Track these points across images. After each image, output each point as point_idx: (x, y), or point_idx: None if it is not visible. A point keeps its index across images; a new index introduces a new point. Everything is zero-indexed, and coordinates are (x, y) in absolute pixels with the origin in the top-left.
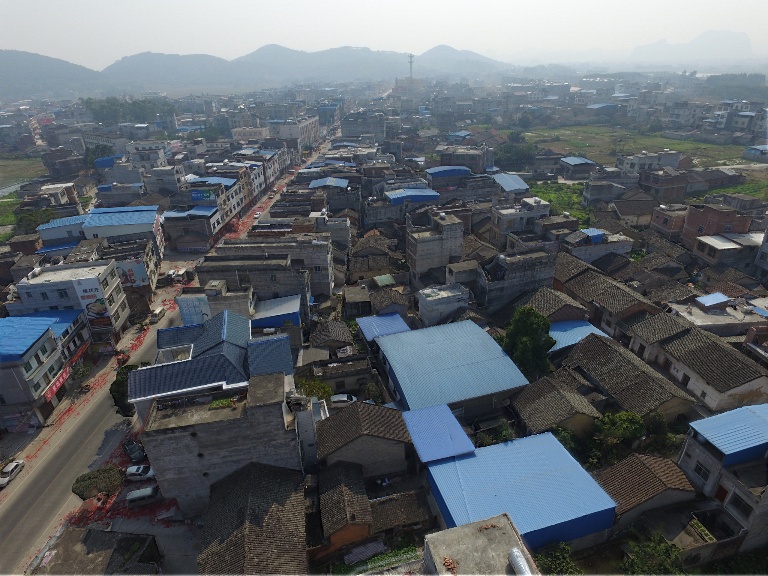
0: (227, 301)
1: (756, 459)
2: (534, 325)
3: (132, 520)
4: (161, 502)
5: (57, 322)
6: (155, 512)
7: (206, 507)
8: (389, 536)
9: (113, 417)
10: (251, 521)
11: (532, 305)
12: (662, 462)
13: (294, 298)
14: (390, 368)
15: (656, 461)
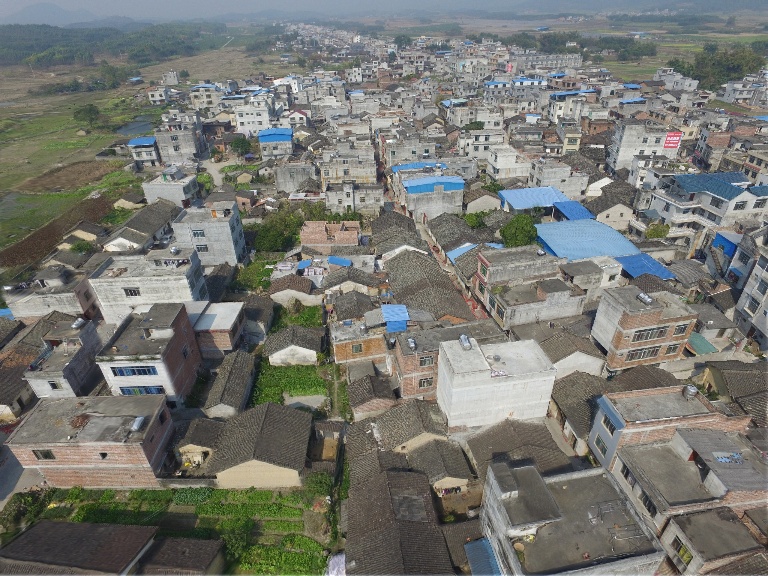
0: None
1: None
2: None
3: None
4: None
5: None
6: None
7: None
8: None
9: None
10: None
11: None
12: None
13: None
14: None
15: (475, 197)
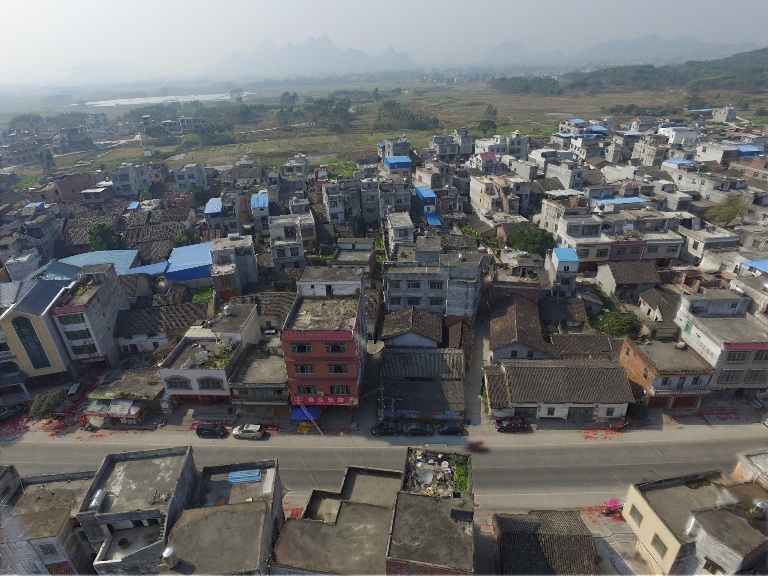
0: None
1: (224, 213)
2: (111, 228)
3: None
4: (86, 386)
5: None
6: (93, 387)
7: (116, 355)
8: None
9: None
10: None
11: (77, 238)
12: None
13: None
14: None
15: None
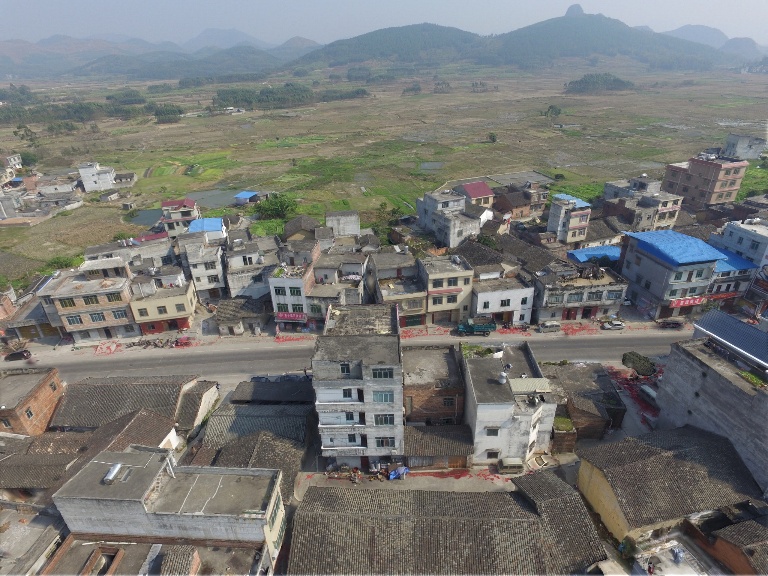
0: None
1: None
2: None
3: (632, 400)
4: (656, 410)
5: (729, 263)
6: (647, 410)
7: None
8: None
9: None
10: (675, 456)
11: None
12: None
13: None
14: None
15: None
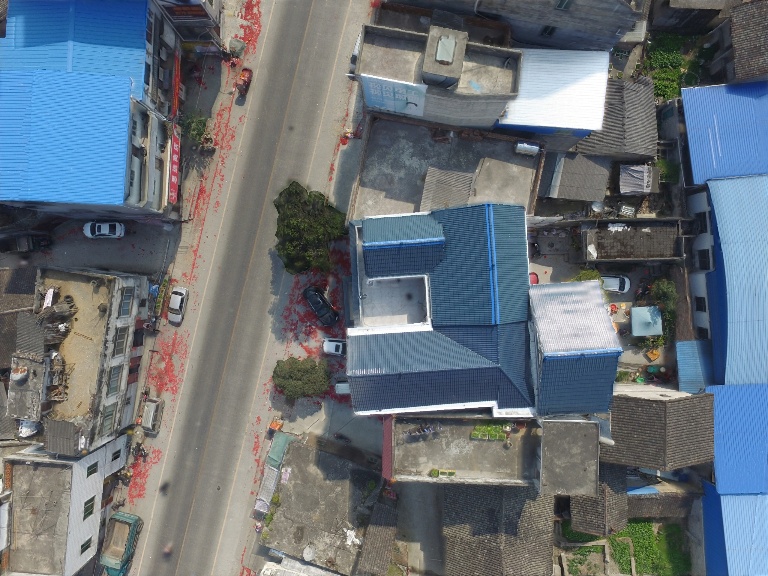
0: (466, 100)
1: None
2: None
3: (344, 406)
4: None
5: (118, 42)
6: None
7: None
8: None
9: (270, 224)
10: (506, 531)
11: None
12: None
13: (594, 66)
14: (717, 276)
15: None
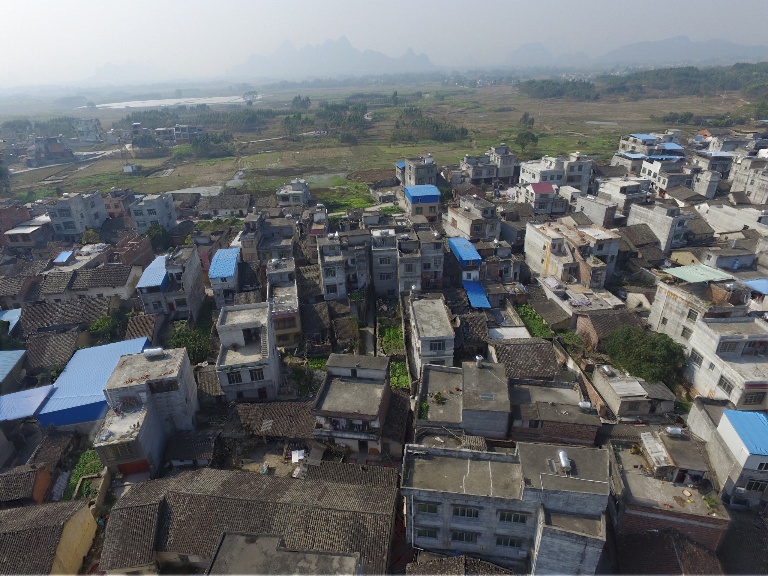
0: None
1: (169, 283)
2: None
3: None
4: None
5: None
6: None
7: None
8: (62, 467)
9: None
10: None
11: None
12: (141, 315)
13: None
14: None
15: None
